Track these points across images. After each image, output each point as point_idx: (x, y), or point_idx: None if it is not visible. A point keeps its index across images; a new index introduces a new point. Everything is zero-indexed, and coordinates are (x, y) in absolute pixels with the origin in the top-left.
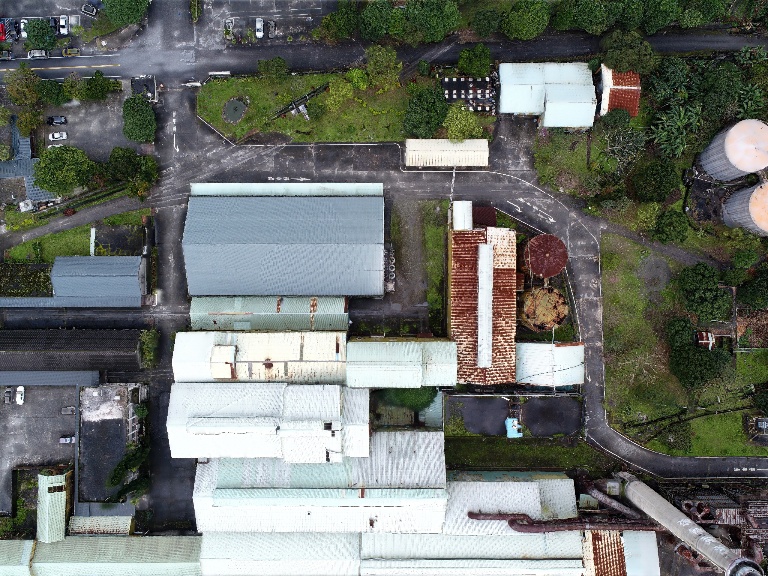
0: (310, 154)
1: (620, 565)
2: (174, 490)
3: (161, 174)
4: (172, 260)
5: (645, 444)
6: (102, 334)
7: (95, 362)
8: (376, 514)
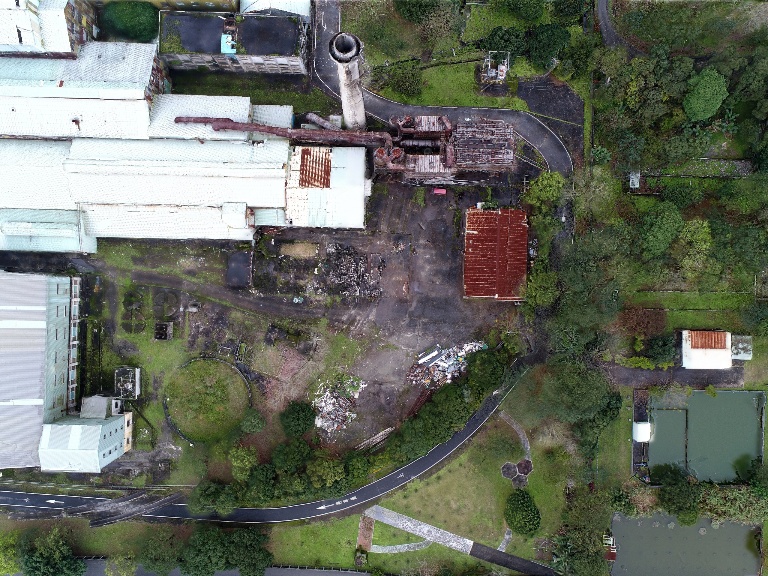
0: None
1: (325, 175)
2: None
3: None
4: None
5: (378, 92)
6: None
7: None
8: (81, 113)
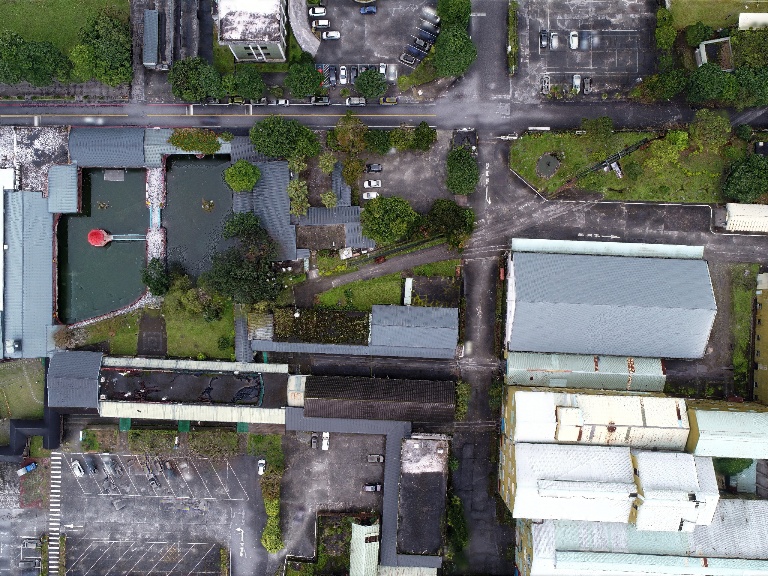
0: (621, 212)
1: None
2: (474, 542)
3: (472, 226)
4: (480, 312)
5: None
6: (418, 385)
7: (411, 413)
8: None
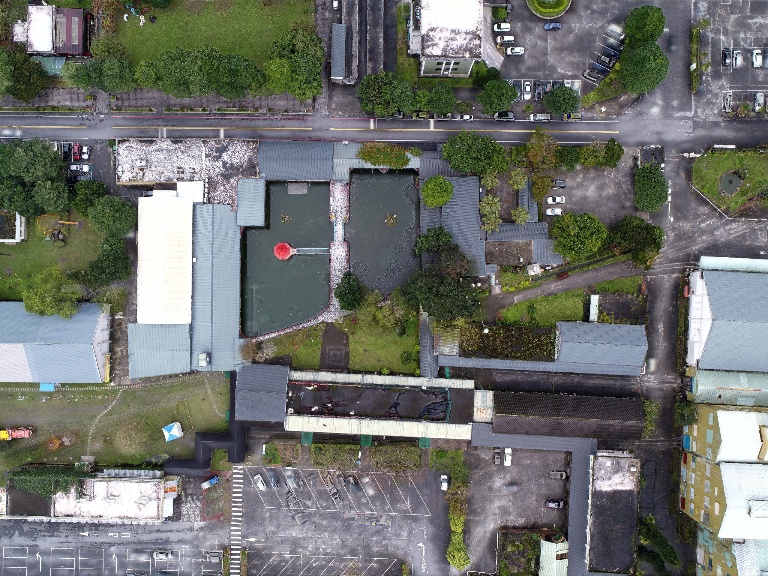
0: None
1: None
2: None
3: None
4: (662, 329)
5: None
6: (606, 402)
7: (600, 430)
8: None
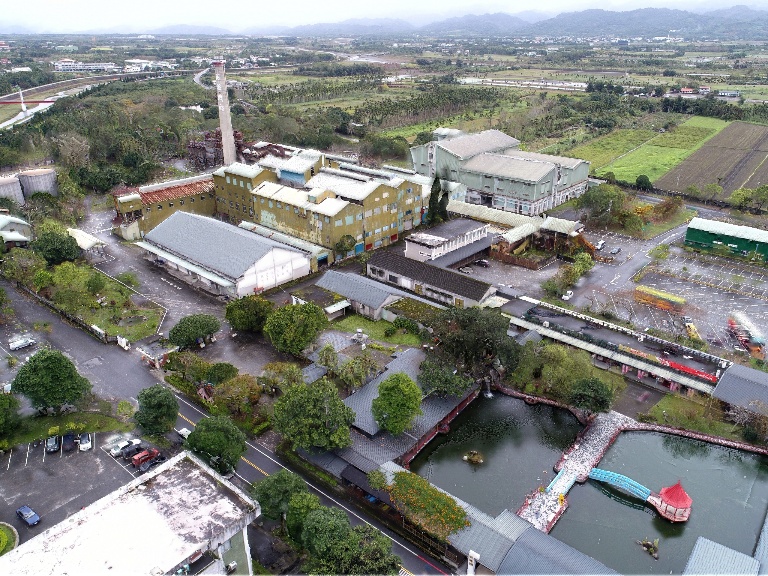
0: None
1: None
2: None
3: None
4: None
5: None
6: (393, 268)
7: None
8: None
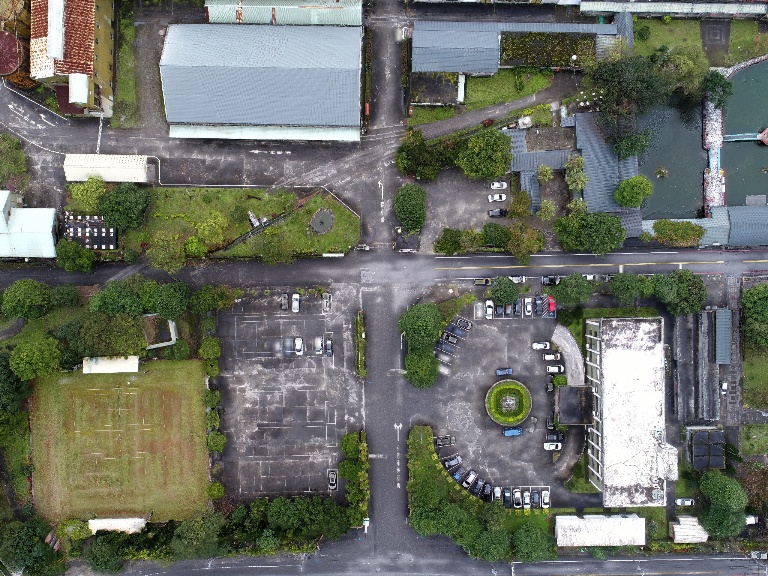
0: (248, 177)
1: None
2: None
3: None
4: (387, 73)
5: None
6: None
7: None
8: None
